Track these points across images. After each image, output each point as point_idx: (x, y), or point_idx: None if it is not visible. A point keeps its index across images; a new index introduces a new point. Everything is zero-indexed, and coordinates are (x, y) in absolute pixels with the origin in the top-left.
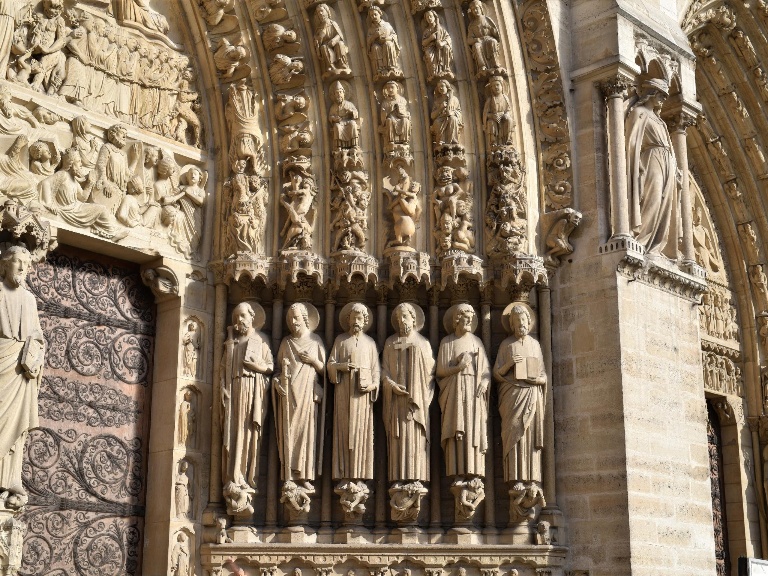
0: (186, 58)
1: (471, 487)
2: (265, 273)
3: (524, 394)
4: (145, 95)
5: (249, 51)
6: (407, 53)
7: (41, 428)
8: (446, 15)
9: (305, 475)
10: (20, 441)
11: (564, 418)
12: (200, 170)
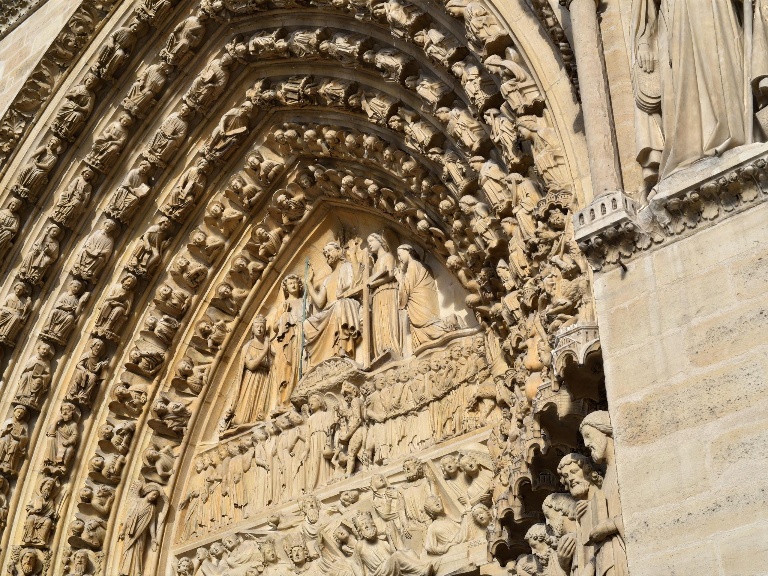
0: (477, 336)
1: None
2: None
3: None
4: (442, 406)
5: (478, 292)
6: None
7: None
8: None
9: None
10: None
11: None
12: None
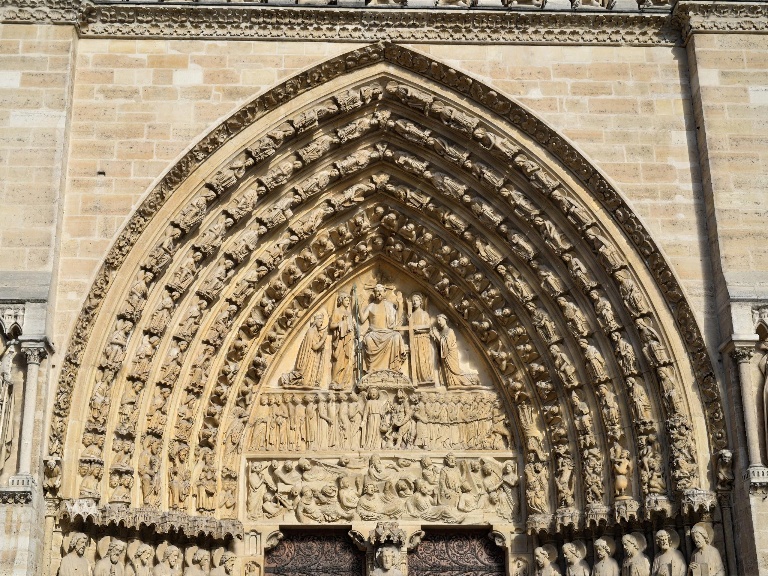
0: (494, 394)
1: None
2: (547, 526)
3: None
4: (468, 428)
5: (523, 383)
6: (610, 362)
7: None
8: (627, 331)
9: None
10: None
11: None
12: (512, 463)
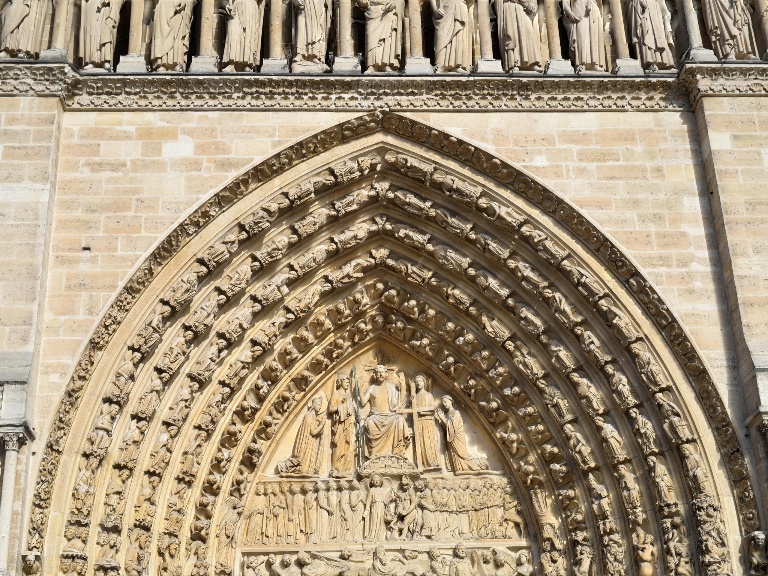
0: (505, 479)
1: None
2: None
3: None
4: (478, 516)
5: (536, 466)
6: (628, 441)
7: None
8: (646, 407)
9: None
10: None
11: None
12: (526, 553)
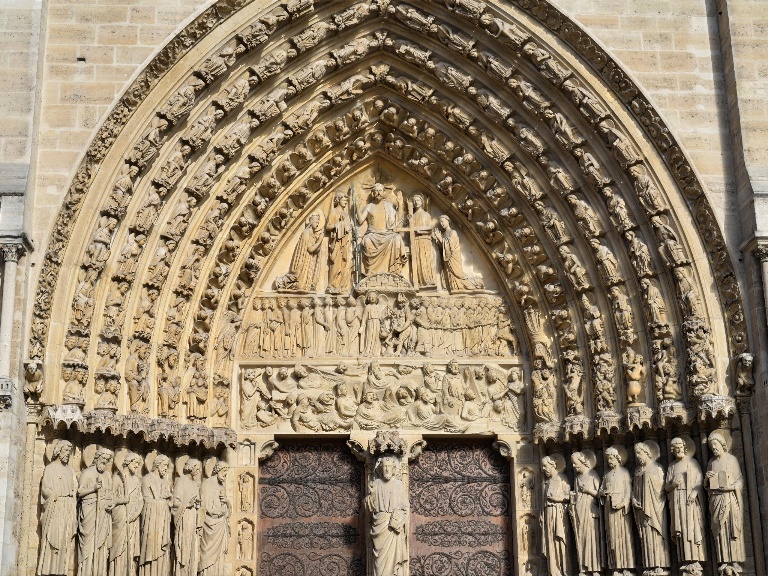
0: (499, 299)
1: (687, 570)
2: (555, 435)
3: (719, 499)
4: (472, 334)
5: (530, 287)
6: (623, 263)
7: (438, 553)
8: (642, 230)
9: (592, 568)
10: (402, 568)
11: (764, 511)
12: (518, 371)
